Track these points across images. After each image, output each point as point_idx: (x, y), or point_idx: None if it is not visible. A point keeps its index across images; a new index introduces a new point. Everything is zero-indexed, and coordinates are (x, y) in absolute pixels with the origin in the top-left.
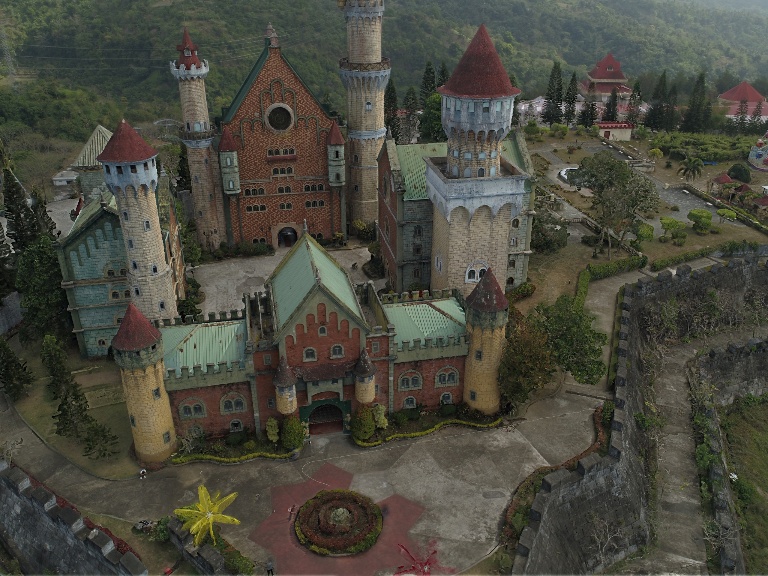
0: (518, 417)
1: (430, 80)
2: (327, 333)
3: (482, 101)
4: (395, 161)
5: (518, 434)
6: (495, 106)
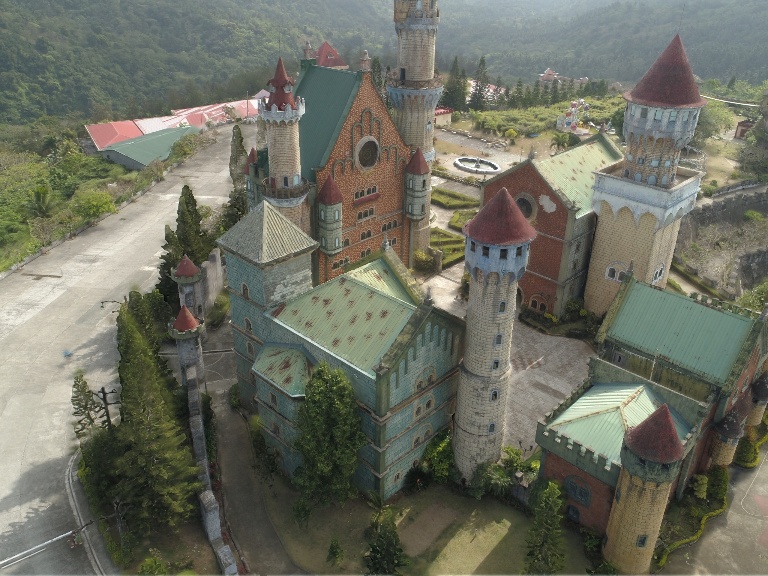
0: None
1: None
2: None
3: None
4: (551, 180)
5: None
6: None
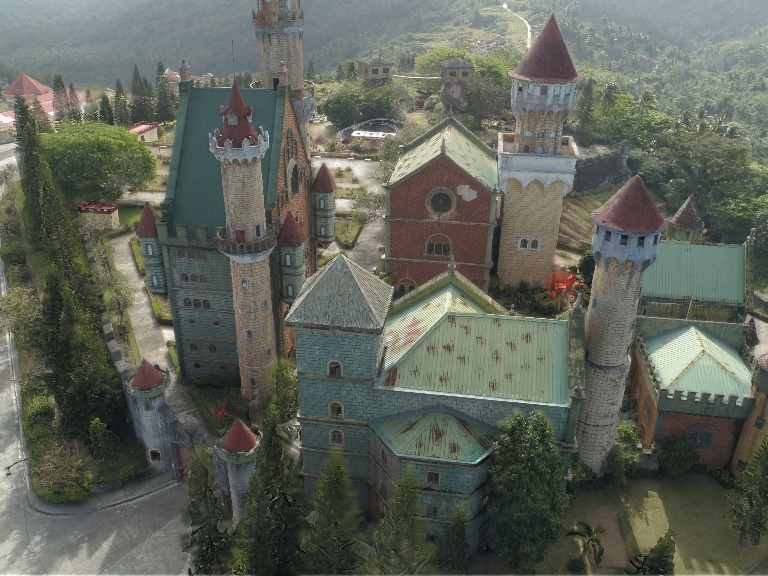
0: None
1: (31, 121)
2: None
3: None
4: (467, 169)
5: None
6: None
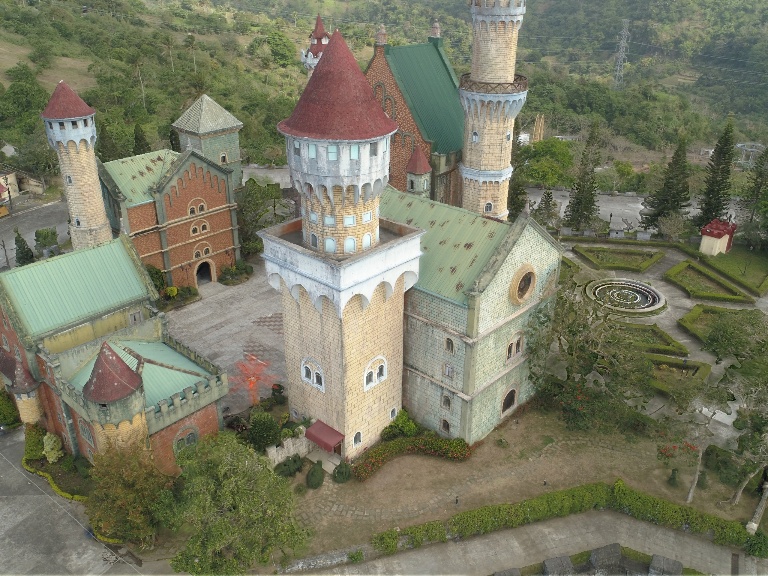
0: (139, 556)
1: None
2: None
3: None
4: None
5: (102, 569)
6: (307, 149)
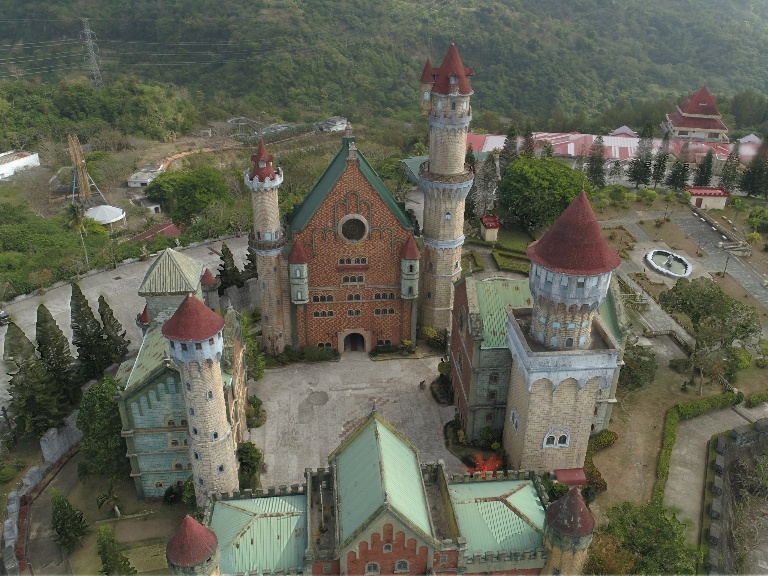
0: None
1: (512, 146)
2: (392, 550)
3: (577, 277)
4: (474, 302)
5: None
6: (591, 281)
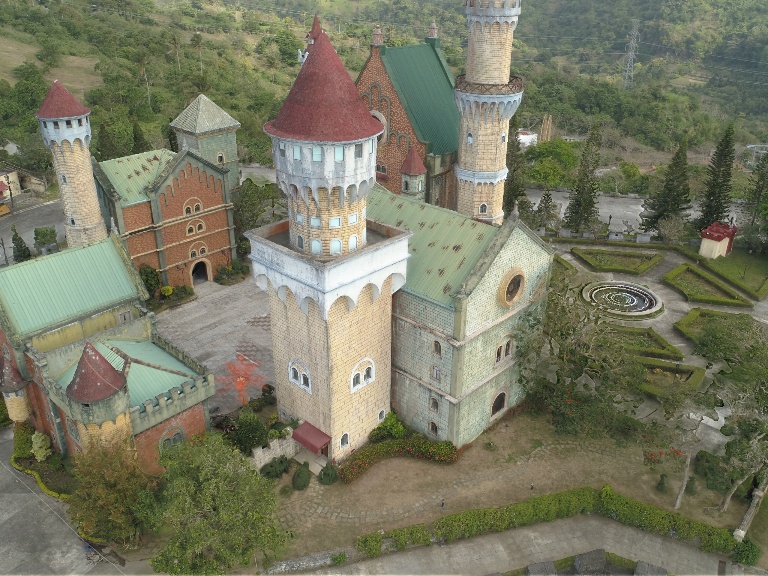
0: (122, 556)
1: None
2: None
3: None
4: None
5: (85, 569)
6: (291, 150)
